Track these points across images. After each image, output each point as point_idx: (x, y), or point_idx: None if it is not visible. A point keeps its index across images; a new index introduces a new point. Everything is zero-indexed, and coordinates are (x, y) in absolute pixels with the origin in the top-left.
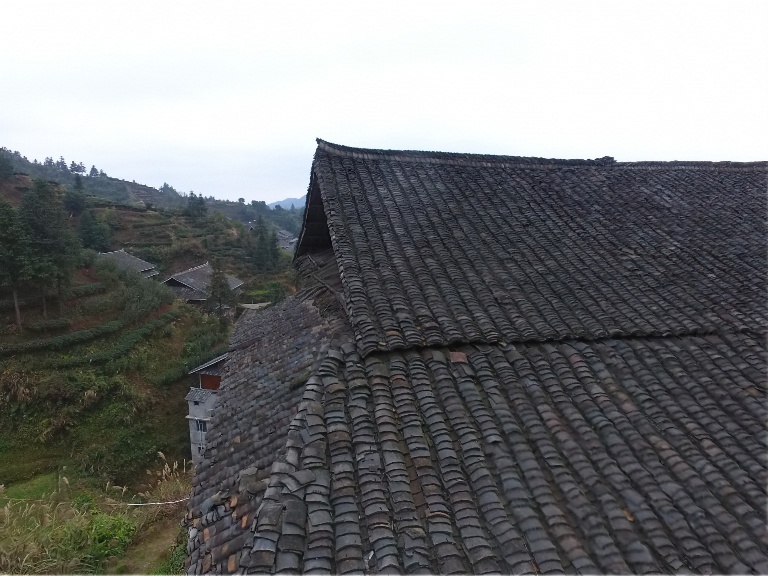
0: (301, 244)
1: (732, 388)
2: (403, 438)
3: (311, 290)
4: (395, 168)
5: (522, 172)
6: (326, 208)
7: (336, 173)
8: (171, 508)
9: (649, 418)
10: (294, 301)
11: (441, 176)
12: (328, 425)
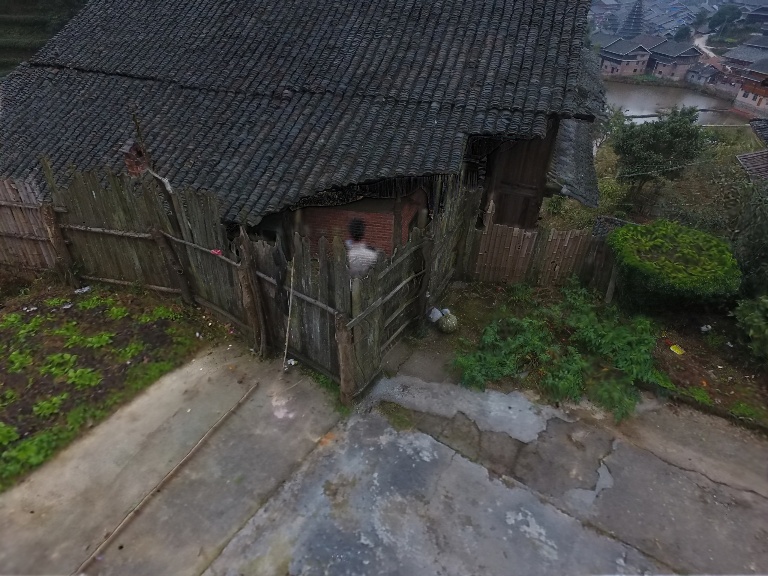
0: None
1: None
2: None
3: None
4: None
5: None
6: None
7: None
8: None
9: None
10: None
11: None
12: None
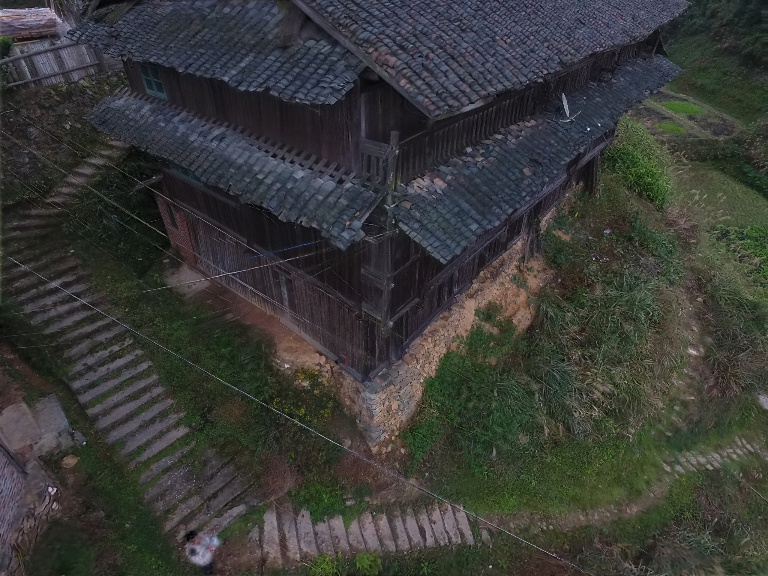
0: None
1: None
2: None
3: None
4: None
5: None
6: None
7: None
8: (672, 217)
9: None
10: None
11: None
12: None
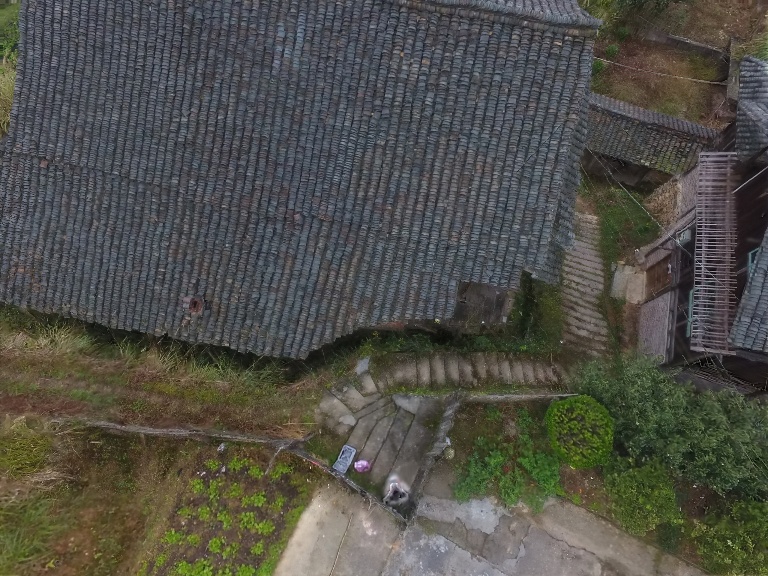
0: None
1: (145, 215)
2: None
3: None
4: None
5: None
6: None
7: None
8: None
9: None
10: None
11: None
12: None
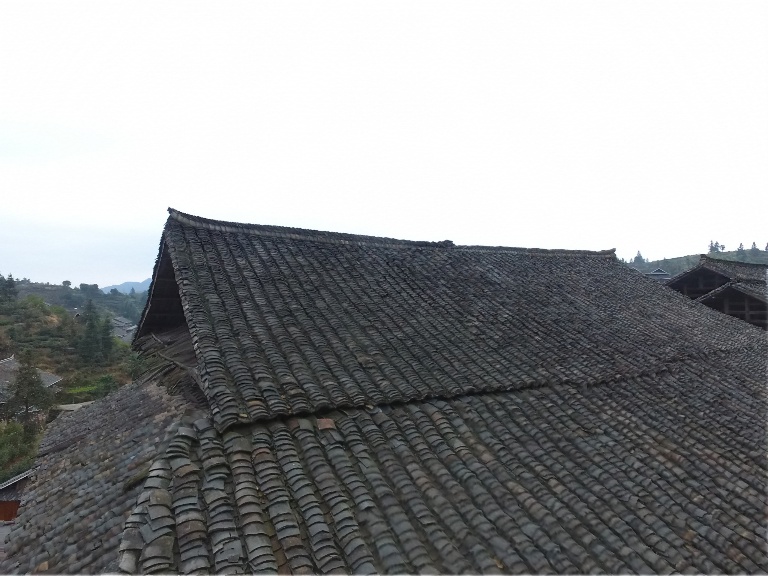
0: (144, 323)
1: (565, 431)
2: (268, 518)
3: (156, 369)
4: (255, 241)
5: (377, 250)
6: (178, 277)
7: (190, 243)
8: None
9: (505, 466)
10: (132, 389)
11: (301, 250)
12: (177, 515)
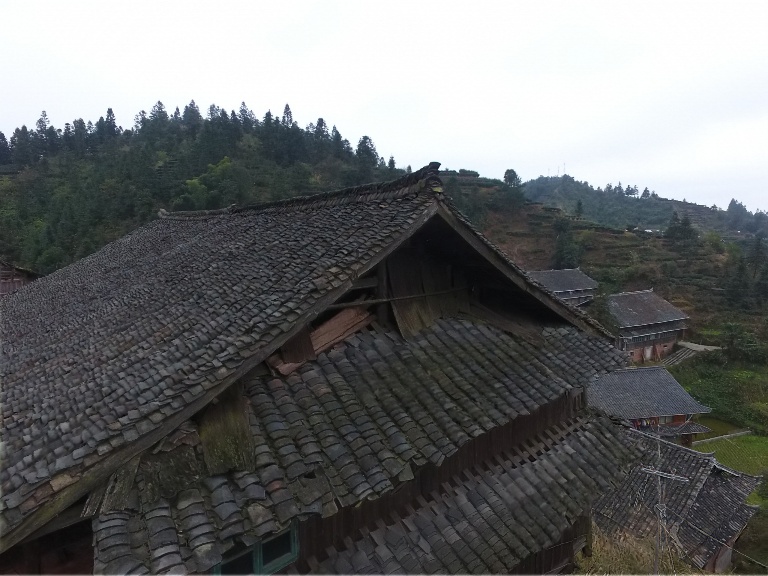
0: None
1: None
2: None
3: None
4: None
5: None
6: None
7: None
8: None
9: None
10: None
11: None
12: None
